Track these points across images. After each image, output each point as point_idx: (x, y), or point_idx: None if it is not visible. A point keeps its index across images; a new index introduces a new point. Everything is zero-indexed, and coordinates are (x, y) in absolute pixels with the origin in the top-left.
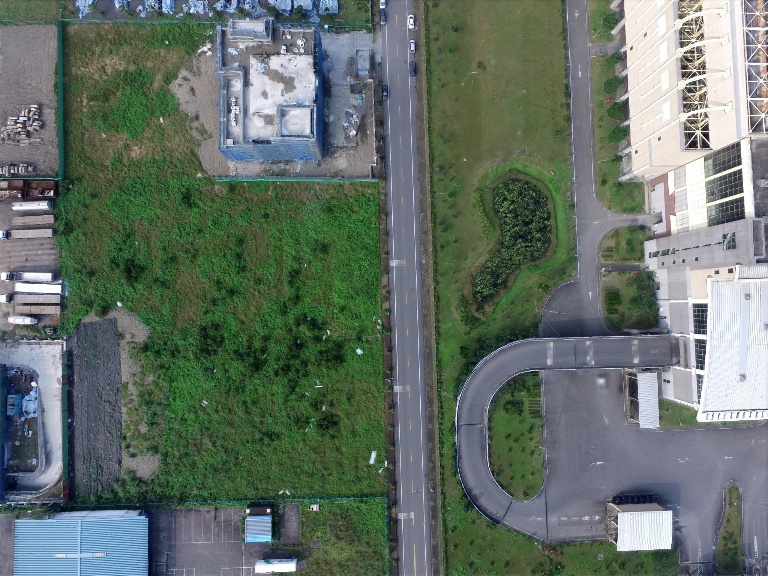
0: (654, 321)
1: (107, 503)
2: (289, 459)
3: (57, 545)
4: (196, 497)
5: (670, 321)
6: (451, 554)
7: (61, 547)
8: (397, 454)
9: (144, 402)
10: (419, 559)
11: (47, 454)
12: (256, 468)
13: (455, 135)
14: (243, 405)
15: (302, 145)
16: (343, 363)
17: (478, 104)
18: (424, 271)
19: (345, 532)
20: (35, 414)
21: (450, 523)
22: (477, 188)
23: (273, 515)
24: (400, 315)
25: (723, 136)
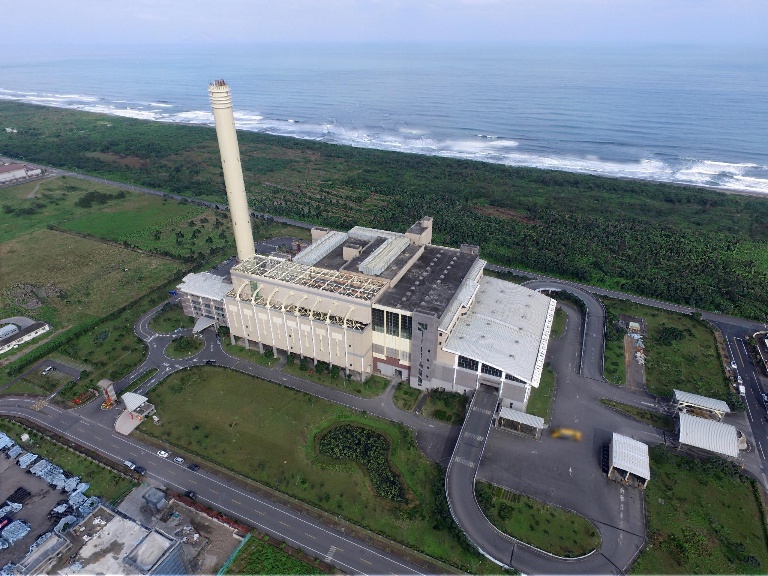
0: (465, 397)
1: None
2: None
3: None
4: None
5: (468, 387)
6: None
7: None
8: None
9: None
10: None
11: None
12: None
13: (263, 461)
14: None
15: (170, 567)
16: None
17: (255, 437)
18: (351, 533)
19: None
20: None
21: None
22: (311, 462)
23: None
24: (380, 575)
25: (365, 315)
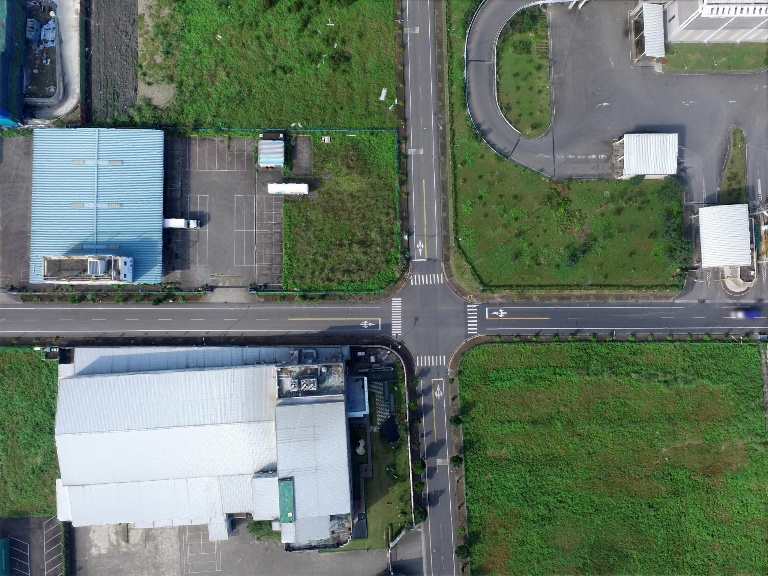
0: None
1: (123, 126)
2: (301, 92)
3: (75, 152)
4: (210, 125)
5: None
6: (460, 189)
7: (79, 154)
8: (407, 93)
9: (160, 32)
10: (428, 194)
11: (64, 86)
12: (269, 101)
13: None
14: (256, 39)
15: None
16: (354, 2)
17: None
18: None
19: (356, 161)
20: (53, 43)
21: (459, 159)
22: None
23: (285, 143)
24: None
25: None
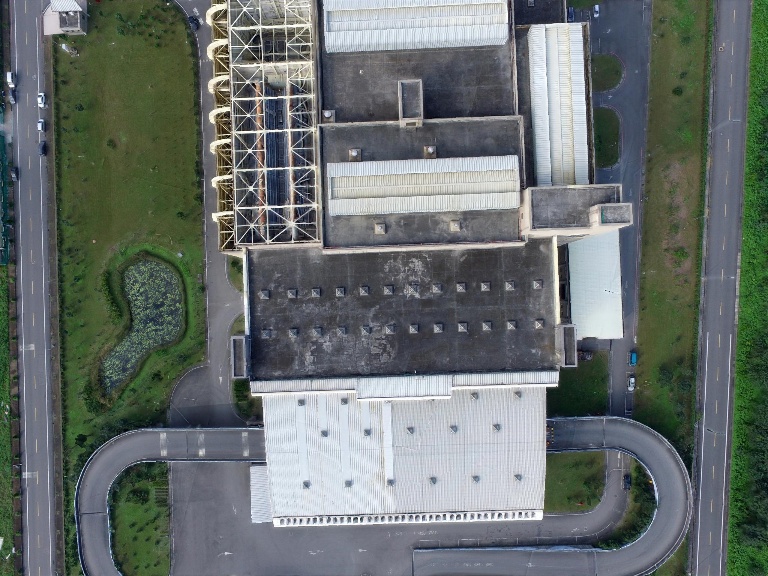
0: None
1: None
2: None
3: None
4: None
5: None
6: None
7: None
8: (25, 540)
9: None
10: None
11: None
12: None
13: (85, 216)
14: None
15: None
16: None
17: (108, 184)
18: (53, 356)
19: None
20: None
21: None
22: (103, 271)
23: None
24: (29, 400)
25: None
